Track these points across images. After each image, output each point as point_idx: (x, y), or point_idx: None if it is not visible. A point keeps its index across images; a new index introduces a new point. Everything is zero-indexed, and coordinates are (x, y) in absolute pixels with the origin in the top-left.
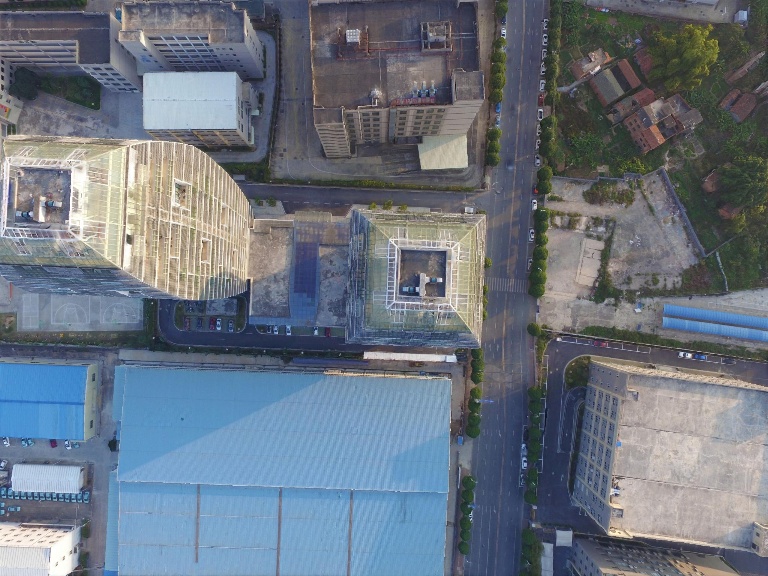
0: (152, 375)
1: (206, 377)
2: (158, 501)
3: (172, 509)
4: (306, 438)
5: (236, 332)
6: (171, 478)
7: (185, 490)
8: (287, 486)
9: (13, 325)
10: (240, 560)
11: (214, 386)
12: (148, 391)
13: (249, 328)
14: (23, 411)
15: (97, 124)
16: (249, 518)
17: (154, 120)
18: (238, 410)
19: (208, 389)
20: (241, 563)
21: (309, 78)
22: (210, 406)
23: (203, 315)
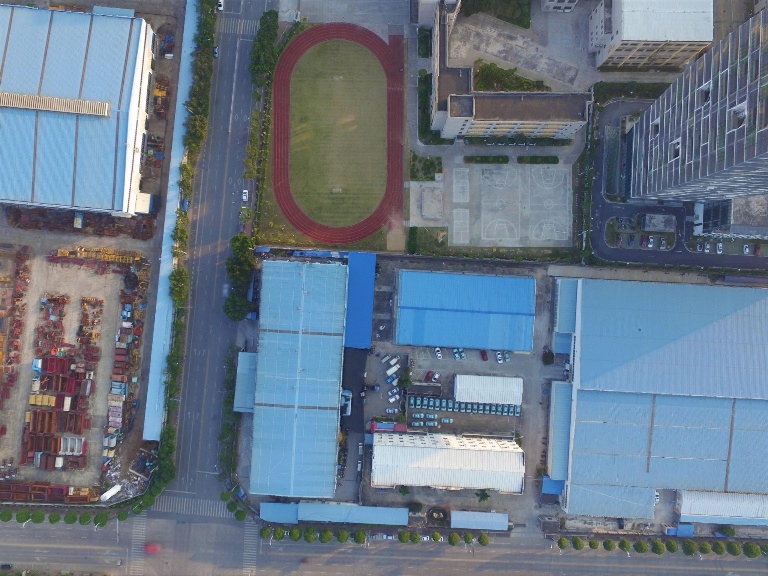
0: (607, 286)
1: (660, 289)
2: (614, 411)
3: (627, 419)
4: (761, 350)
5: (666, 250)
6: (632, 387)
7: (641, 400)
8: (746, 397)
9: (445, 240)
10: (690, 471)
11: (668, 298)
12: (604, 302)
13: (679, 246)
14: (474, 321)
15: (527, 43)
16: (702, 429)
17: (633, 31)
18: (693, 322)
19: (663, 301)
20: (691, 474)
21: (736, 1)
22: (666, 318)
23: (634, 232)
